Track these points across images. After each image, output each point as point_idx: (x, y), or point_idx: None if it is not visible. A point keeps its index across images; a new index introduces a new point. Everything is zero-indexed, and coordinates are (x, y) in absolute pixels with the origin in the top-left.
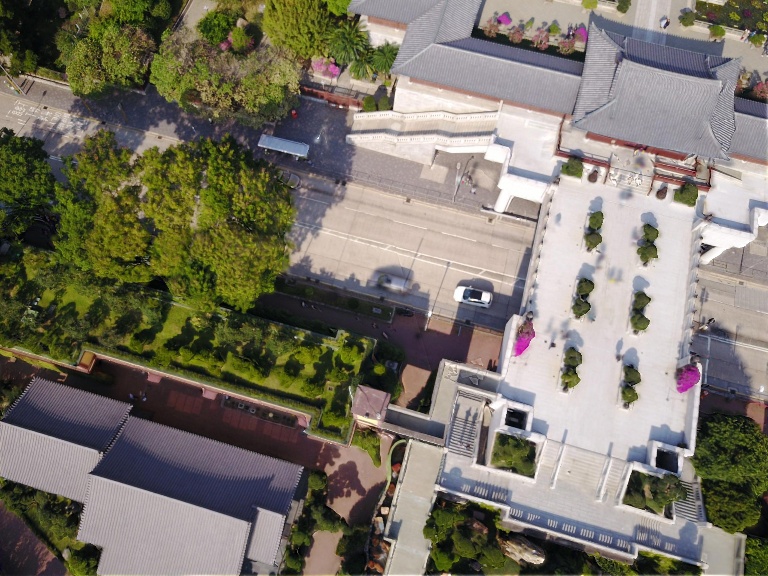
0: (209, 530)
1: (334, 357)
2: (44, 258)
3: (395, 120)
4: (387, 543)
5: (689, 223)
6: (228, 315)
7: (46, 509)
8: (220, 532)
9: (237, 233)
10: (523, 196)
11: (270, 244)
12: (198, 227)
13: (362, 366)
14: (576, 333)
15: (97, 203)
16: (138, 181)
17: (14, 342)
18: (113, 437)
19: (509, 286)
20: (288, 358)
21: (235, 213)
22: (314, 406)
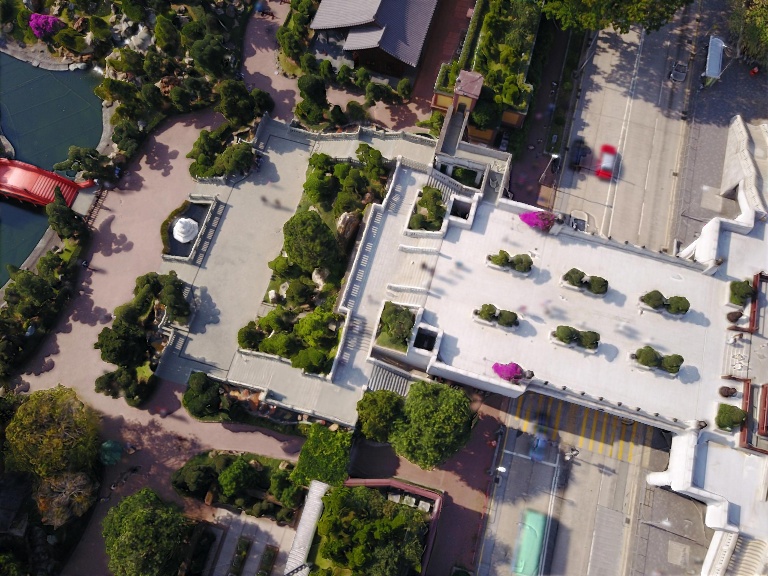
0: None
1: None
2: None
3: (767, 151)
4: None
5: None
6: (538, 5)
7: None
8: (368, 6)
9: None
10: (697, 254)
11: None
12: None
13: None
14: (548, 279)
15: None
16: None
17: None
18: None
19: None
20: None
21: None
22: (465, 67)
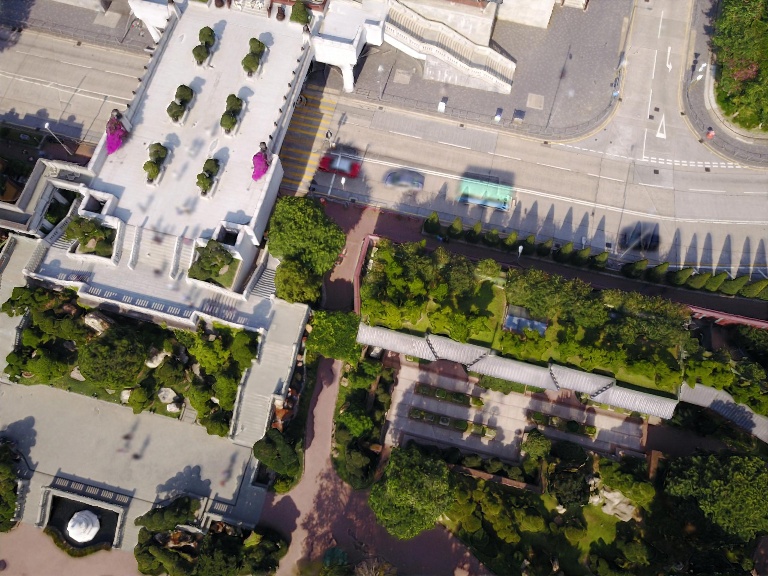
0: None
1: None
2: None
3: None
4: None
5: (302, 40)
6: None
7: None
8: None
9: None
10: (161, 25)
11: None
12: None
13: None
14: (175, 136)
15: None
16: None
17: None
18: None
19: None
20: None
21: None
22: None
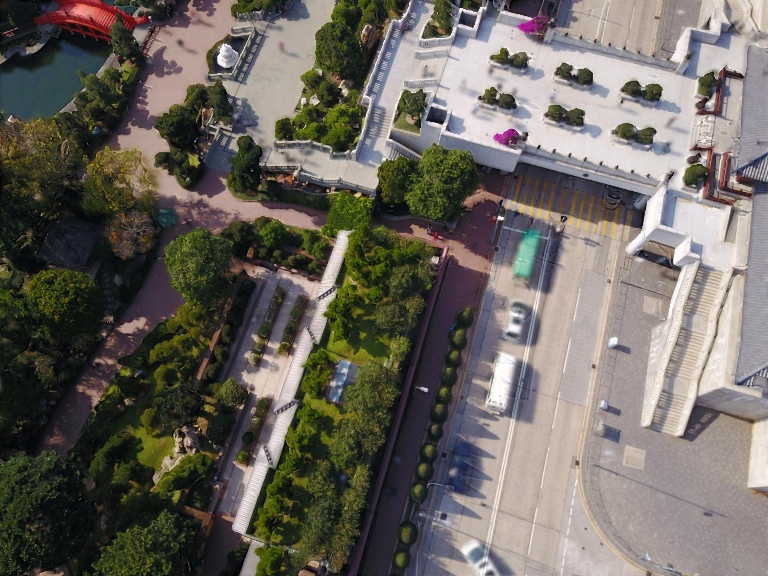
0: None
1: None
2: None
3: None
4: None
5: None
6: None
7: None
8: None
9: None
10: None
11: None
12: None
13: None
14: (542, 76)
15: None
16: None
17: None
18: None
19: None
20: None
21: None
22: None
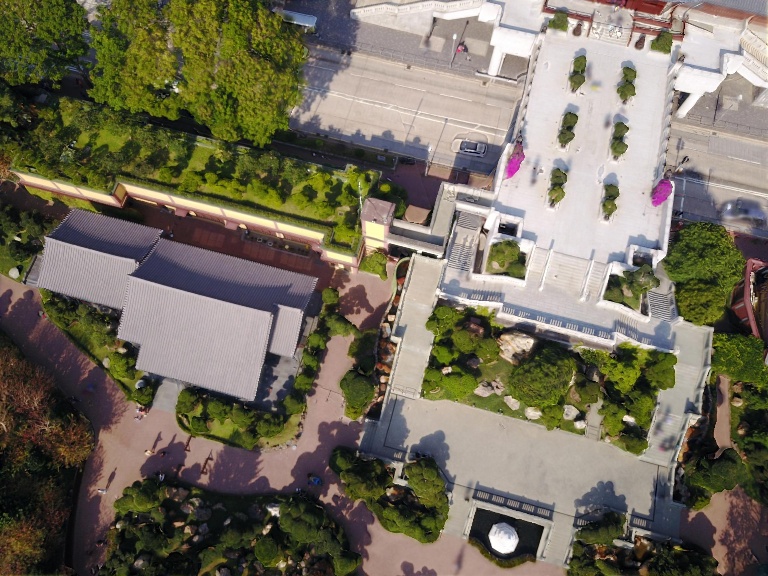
0: (235, 324)
1: (344, 188)
2: (79, 106)
3: None
4: (394, 344)
5: (665, 69)
6: (247, 152)
7: (89, 315)
8: (245, 325)
9: (256, 60)
10: (514, 52)
11: (285, 75)
12: (221, 56)
13: (369, 192)
14: (562, 161)
15: (129, 40)
16: (166, 19)
17: (55, 173)
18: (147, 253)
19: (502, 138)
20: (302, 189)
21: (254, 46)
22: (327, 226)
